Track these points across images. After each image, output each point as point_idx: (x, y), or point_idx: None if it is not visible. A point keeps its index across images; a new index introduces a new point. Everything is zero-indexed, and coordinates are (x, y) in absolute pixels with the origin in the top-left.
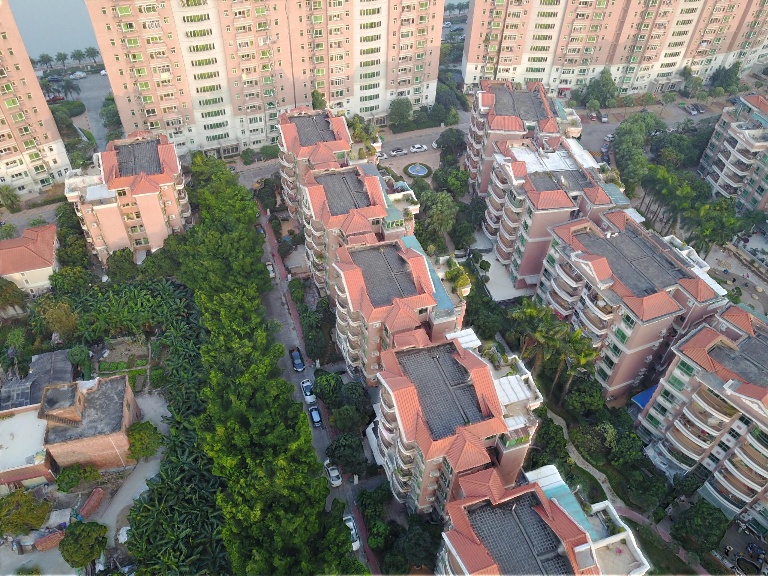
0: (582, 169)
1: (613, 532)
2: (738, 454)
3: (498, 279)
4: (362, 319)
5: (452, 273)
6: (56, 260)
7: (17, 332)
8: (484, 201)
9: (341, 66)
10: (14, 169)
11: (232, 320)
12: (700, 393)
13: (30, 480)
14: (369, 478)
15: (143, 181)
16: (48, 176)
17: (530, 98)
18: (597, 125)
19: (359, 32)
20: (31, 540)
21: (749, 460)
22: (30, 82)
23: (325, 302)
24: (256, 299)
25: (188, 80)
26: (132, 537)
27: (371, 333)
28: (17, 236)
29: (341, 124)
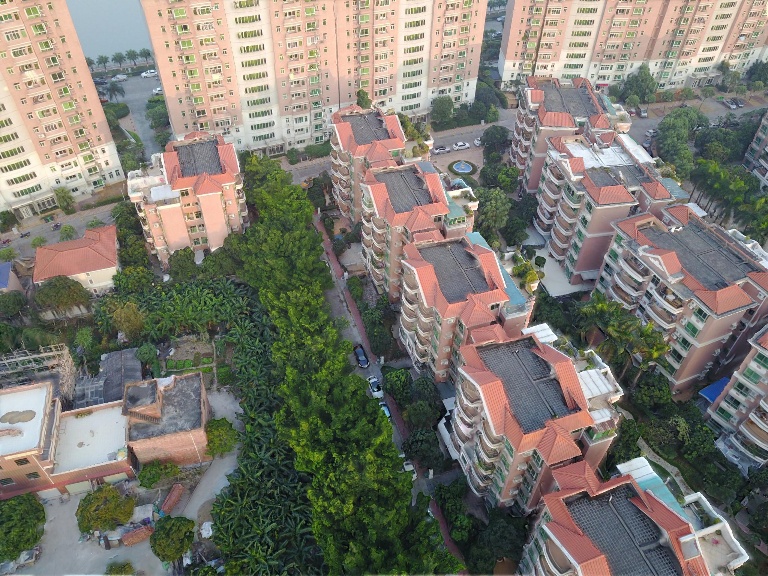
0: (638, 164)
1: (708, 523)
2: None
3: (553, 275)
4: (436, 315)
5: (519, 269)
6: (118, 260)
7: (85, 331)
8: (535, 197)
9: (385, 65)
10: (69, 171)
11: (298, 317)
12: None
13: (112, 476)
14: (443, 473)
15: (206, 181)
16: (100, 178)
17: (578, 94)
18: (637, 121)
19: (404, 31)
20: (118, 535)
21: None
22: (86, 85)
23: (386, 299)
24: (320, 297)
25: (237, 81)
26: (217, 531)
27: (445, 329)
28: (76, 237)
29: (395, 122)
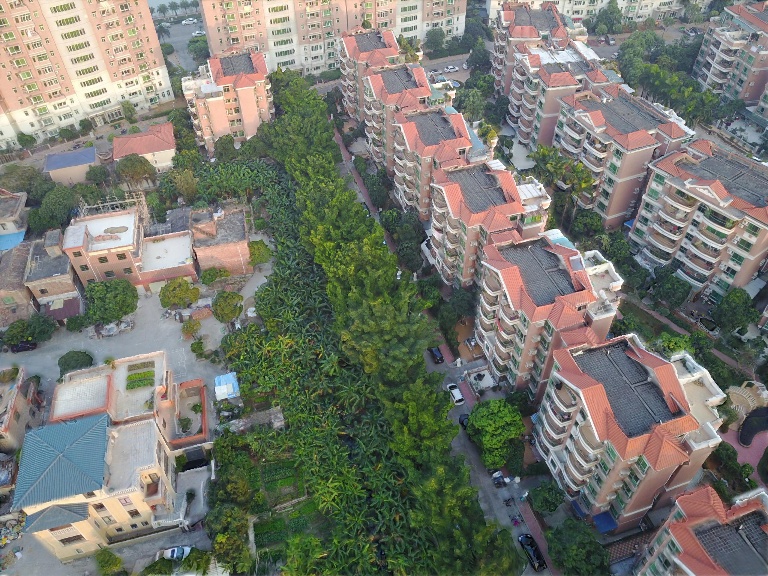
0: (585, 60)
1: None
2: (698, 235)
3: (520, 156)
4: (417, 158)
5: (483, 130)
6: None
7: (154, 195)
8: (507, 98)
9: None
10: (132, 88)
11: None
12: (669, 194)
13: None
14: (424, 277)
15: (243, 78)
16: (155, 96)
17: (544, 15)
18: (605, 47)
19: None
20: (188, 312)
21: (705, 237)
22: (145, 16)
23: None
24: None
25: (264, 13)
26: (259, 307)
27: (424, 168)
28: None
29: (390, 36)
